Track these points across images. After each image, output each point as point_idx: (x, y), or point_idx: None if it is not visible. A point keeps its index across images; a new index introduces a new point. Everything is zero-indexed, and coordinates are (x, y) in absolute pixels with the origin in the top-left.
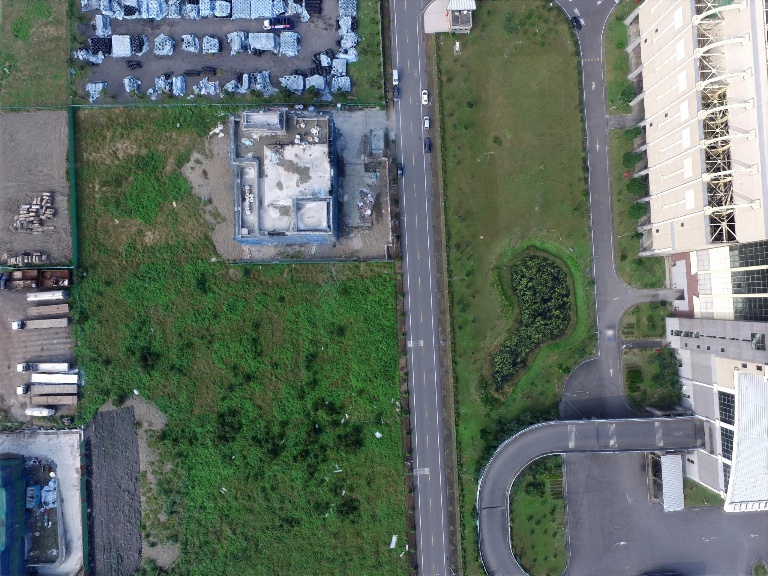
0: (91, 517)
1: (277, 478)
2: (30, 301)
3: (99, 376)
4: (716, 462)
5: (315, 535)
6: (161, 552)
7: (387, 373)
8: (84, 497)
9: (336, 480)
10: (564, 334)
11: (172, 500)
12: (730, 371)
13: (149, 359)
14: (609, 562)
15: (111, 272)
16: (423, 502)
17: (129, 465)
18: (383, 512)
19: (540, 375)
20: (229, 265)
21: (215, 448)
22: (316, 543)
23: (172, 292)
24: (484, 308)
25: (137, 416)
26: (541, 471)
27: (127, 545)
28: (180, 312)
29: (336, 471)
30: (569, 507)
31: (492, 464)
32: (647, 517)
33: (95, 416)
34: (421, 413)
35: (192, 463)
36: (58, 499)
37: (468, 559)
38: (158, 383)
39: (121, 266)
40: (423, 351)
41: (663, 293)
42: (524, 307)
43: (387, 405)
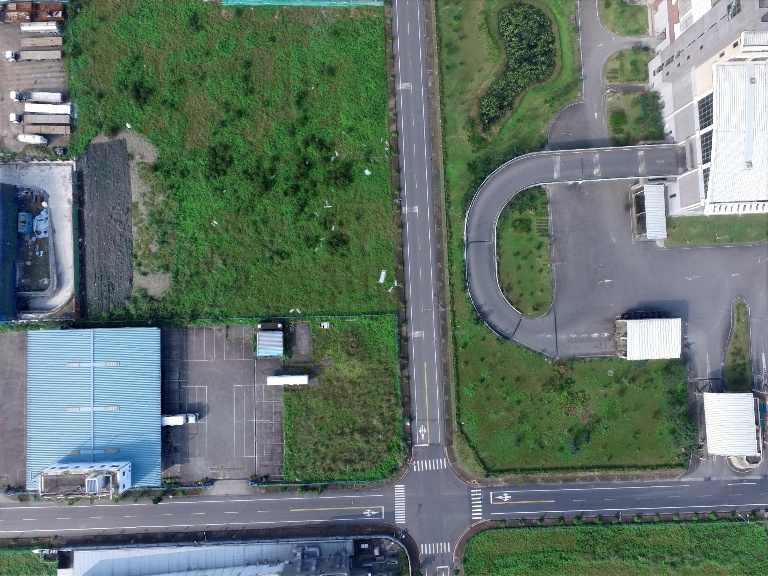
0: (82, 246)
1: (267, 212)
2: (24, 35)
3: (92, 109)
4: (697, 175)
5: (305, 268)
6: (152, 281)
7: (376, 112)
8: (76, 225)
9: (326, 214)
10: (550, 78)
11: (163, 230)
12: (709, 71)
13: (141, 90)
14: (594, 299)
15: (105, 9)
16: (411, 239)
17: (121, 196)
18: (372, 247)
19: (526, 117)
20: (221, 5)
21: (206, 181)
22: (306, 276)
23: (165, 29)
24: (471, 52)
25: (129, 149)
26: (527, 203)
27: (118, 273)
28: (173, 49)
29: (326, 207)
30: (555, 245)
31: (479, 197)
32: (631, 256)
33: (87, 148)
34: (410, 153)
35: (183, 195)
36: (50, 228)
37: (456, 294)
38: (150, 117)
39: (115, 3)
40: (412, 93)
41: (646, 40)
42: (511, 53)
43: (376, 144)
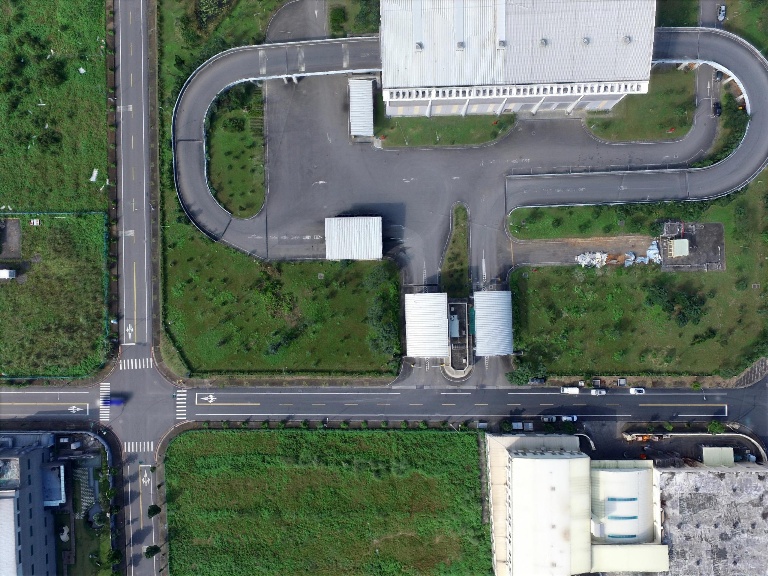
0: None
1: None
2: None
3: None
4: None
5: (17, 166)
6: None
7: (92, 10)
8: None
9: (38, 112)
10: None
11: None
12: None
13: None
14: (307, 201)
15: None
16: (125, 138)
17: None
18: (83, 145)
19: None
20: None
21: None
22: (18, 173)
23: None
24: None
25: None
26: (233, 99)
27: None
28: None
29: (40, 105)
30: (269, 146)
31: (187, 93)
32: (347, 157)
33: None
34: (126, 52)
35: None
36: None
37: (167, 194)
38: None
39: None
40: None
41: None
42: None
43: (92, 42)
